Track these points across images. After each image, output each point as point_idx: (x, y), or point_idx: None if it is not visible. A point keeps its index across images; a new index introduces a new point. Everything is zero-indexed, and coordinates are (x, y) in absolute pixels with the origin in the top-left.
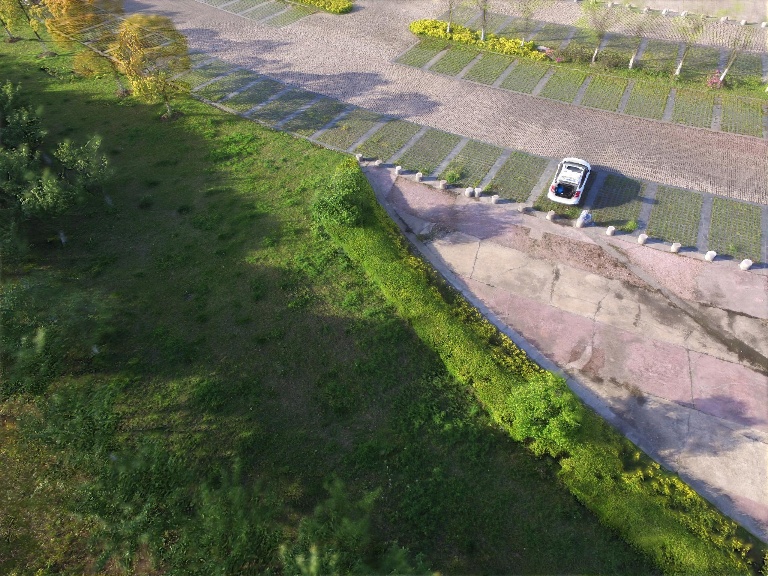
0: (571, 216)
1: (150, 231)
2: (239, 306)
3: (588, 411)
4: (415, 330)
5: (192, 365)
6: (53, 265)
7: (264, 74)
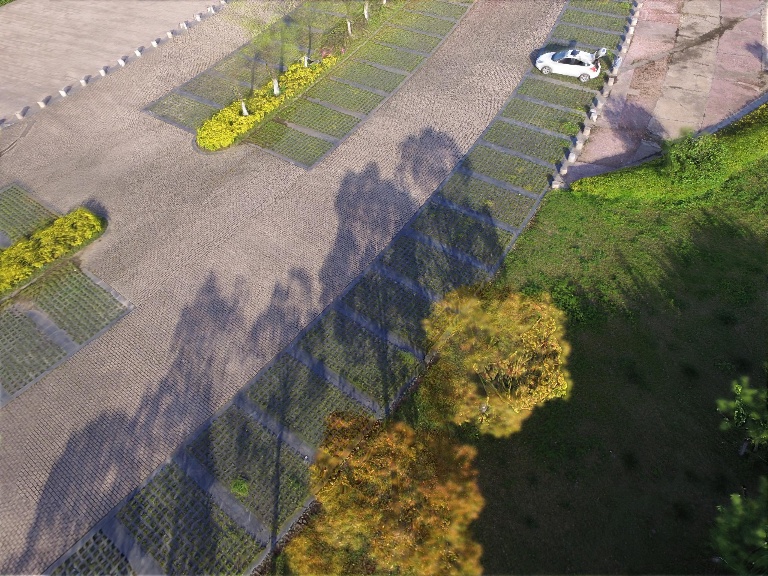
0: (606, 74)
1: None
2: None
3: None
4: None
5: None
6: None
7: (325, 306)
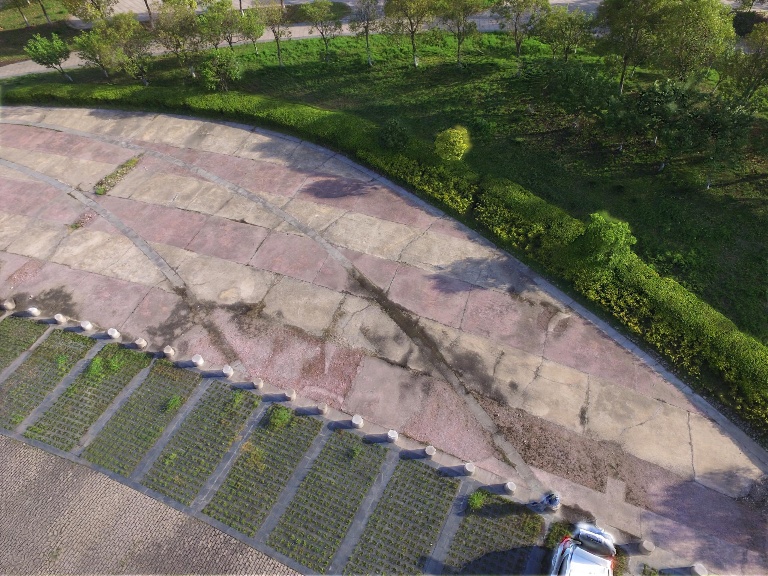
0: (566, 527)
1: None
2: None
3: (559, 273)
4: None
5: None
6: None
7: None
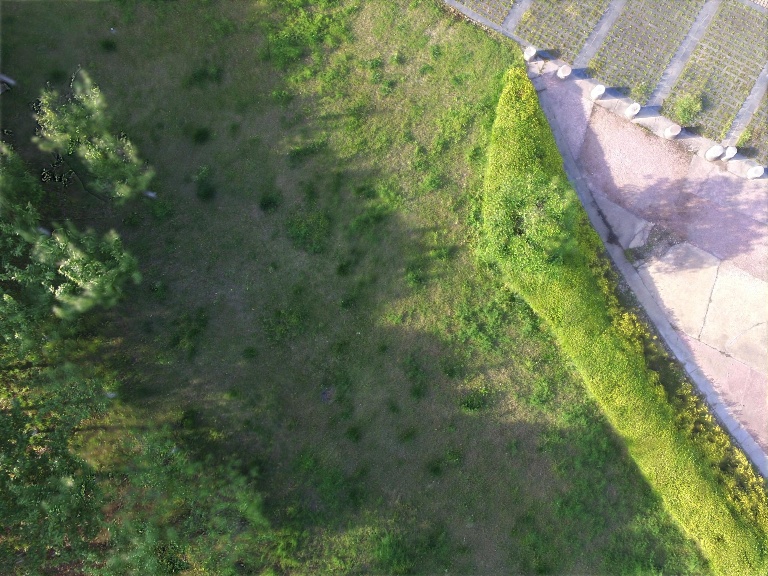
0: None
1: (232, 256)
2: (397, 408)
3: None
4: (628, 447)
5: (364, 509)
6: (123, 336)
7: None
